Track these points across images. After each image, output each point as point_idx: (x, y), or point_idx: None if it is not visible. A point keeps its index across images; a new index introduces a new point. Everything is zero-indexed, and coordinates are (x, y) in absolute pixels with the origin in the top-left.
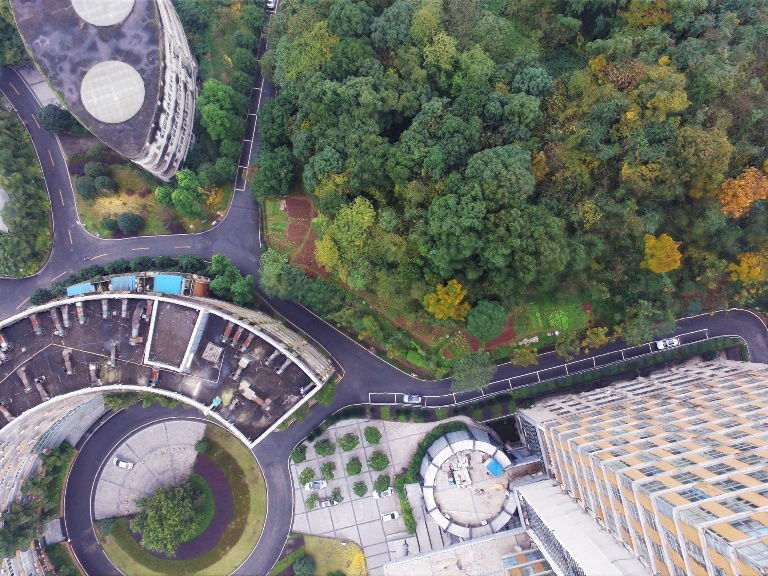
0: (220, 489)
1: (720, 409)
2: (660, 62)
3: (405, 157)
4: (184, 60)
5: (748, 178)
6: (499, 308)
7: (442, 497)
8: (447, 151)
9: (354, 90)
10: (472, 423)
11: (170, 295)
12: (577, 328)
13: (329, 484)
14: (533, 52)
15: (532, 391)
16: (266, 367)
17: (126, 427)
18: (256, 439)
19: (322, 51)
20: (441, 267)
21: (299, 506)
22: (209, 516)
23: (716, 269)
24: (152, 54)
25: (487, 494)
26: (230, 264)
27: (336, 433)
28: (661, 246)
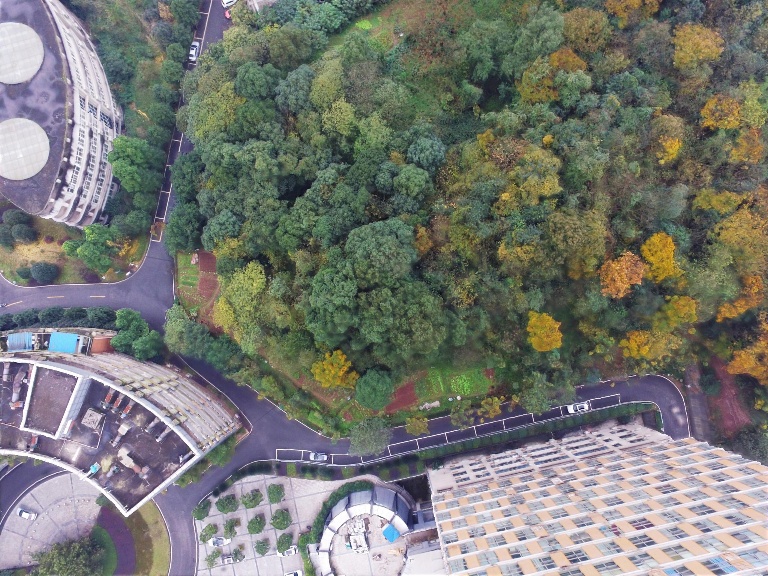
0: (123, 542)
1: (587, 499)
2: (543, 141)
3: (293, 226)
4: (105, 111)
5: (623, 263)
6: (385, 379)
7: (339, 561)
8: (333, 222)
9: (250, 155)
10: (380, 482)
11: (54, 359)
12: (479, 394)
13: (233, 540)
14: (429, 122)
15: (439, 453)
16: (147, 434)
17: (31, 477)
18: (132, 508)
19: (227, 112)
20: (320, 340)
21: (202, 562)
22: (110, 570)
23: (605, 346)
24: (58, 112)
25: (385, 559)
26: (139, 317)
27: (242, 489)
28: (541, 326)
